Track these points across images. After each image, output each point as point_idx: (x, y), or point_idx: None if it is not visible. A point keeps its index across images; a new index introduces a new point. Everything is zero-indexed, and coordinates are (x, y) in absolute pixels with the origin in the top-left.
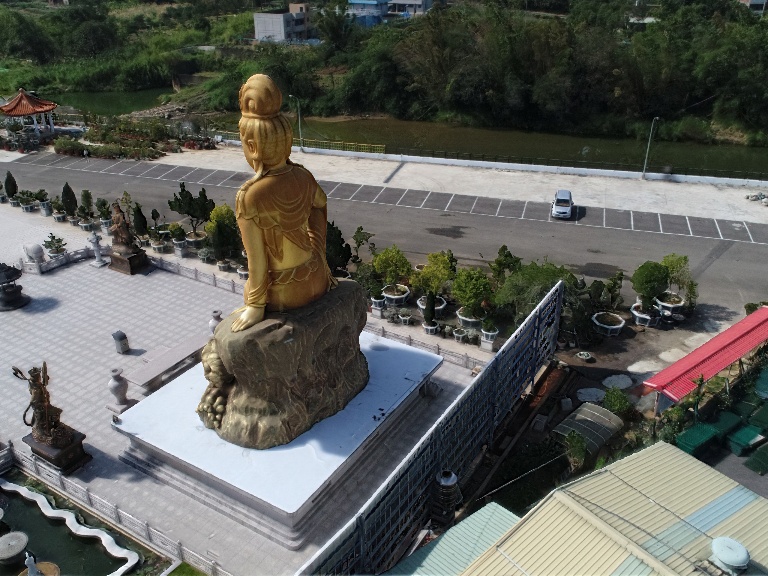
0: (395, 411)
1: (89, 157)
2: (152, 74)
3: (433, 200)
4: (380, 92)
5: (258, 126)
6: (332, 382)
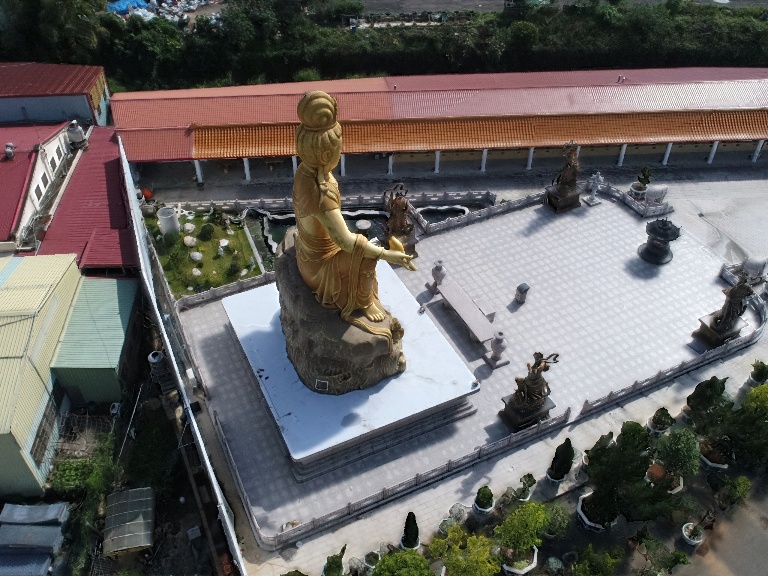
0: None
1: None
2: None
3: None
4: None
5: None
6: None
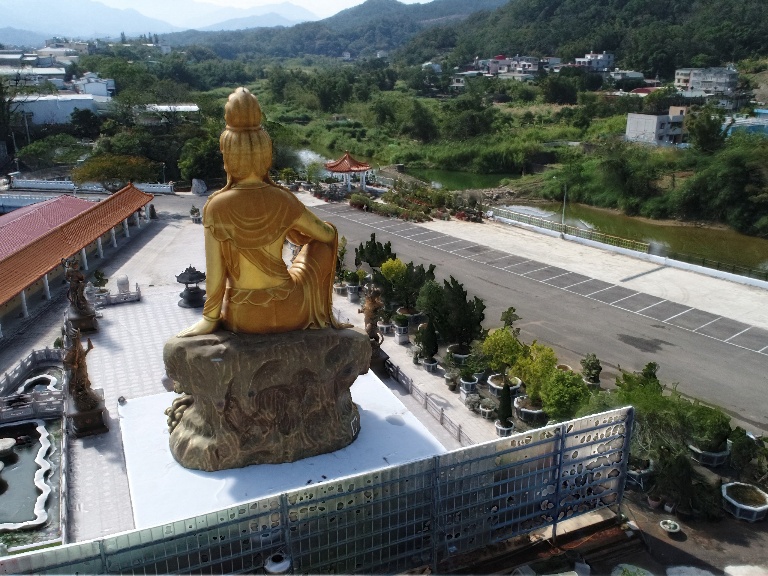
0: None
1: (370, 212)
2: (507, 160)
3: (660, 308)
4: (722, 200)
5: (225, 137)
6: (287, 428)
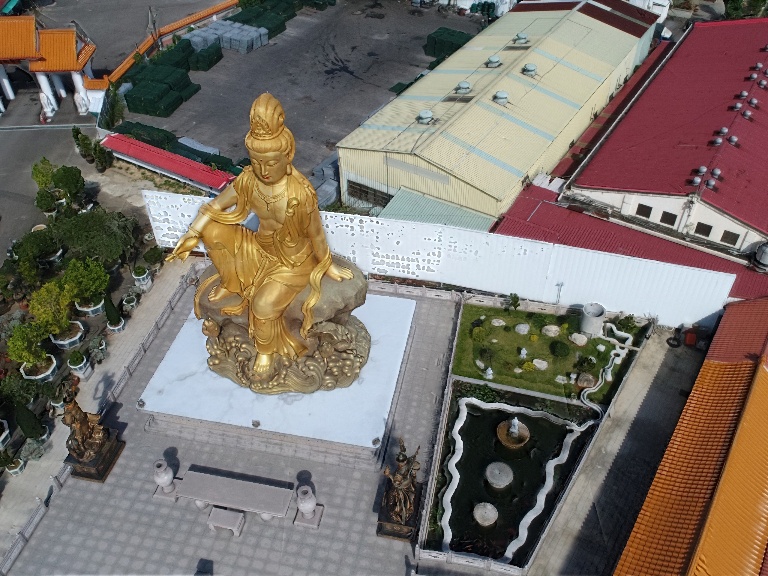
0: None
1: None
2: None
3: None
4: None
5: None
6: None
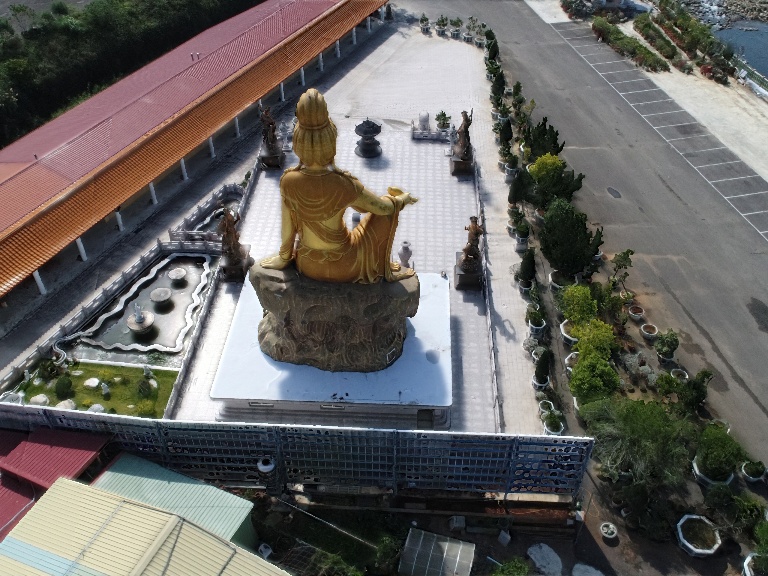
0: (355, 404)
1: (608, 44)
2: None
3: None
4: None
5: (295, 131)
6: (333, 347)
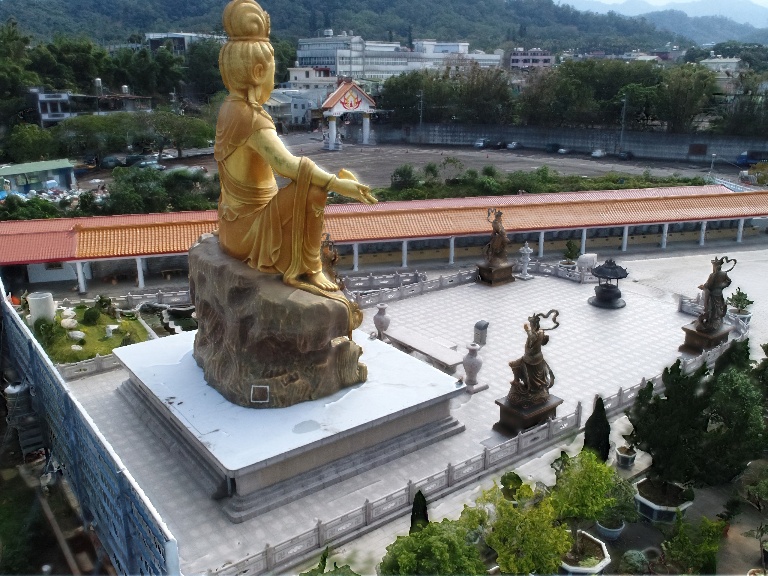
0: None
1: None
2: None
3: None
4: None
5: None
6: None
